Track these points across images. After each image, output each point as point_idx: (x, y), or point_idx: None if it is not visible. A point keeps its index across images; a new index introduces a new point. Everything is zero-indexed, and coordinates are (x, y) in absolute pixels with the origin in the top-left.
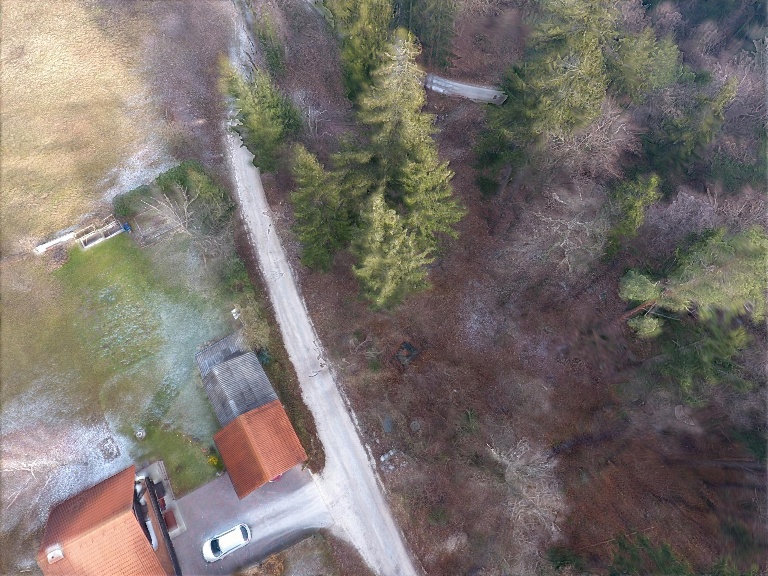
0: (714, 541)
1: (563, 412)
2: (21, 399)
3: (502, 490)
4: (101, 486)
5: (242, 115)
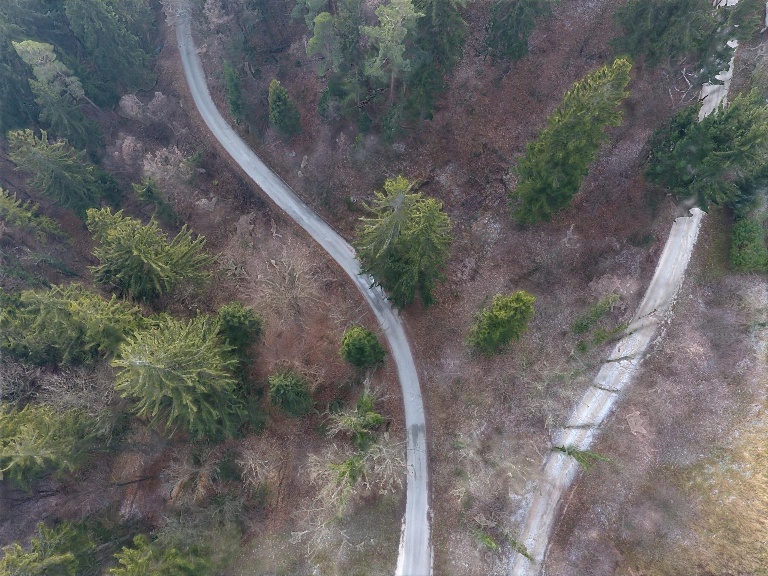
0: None
1: None
2: None
3: None
4: None
5: None
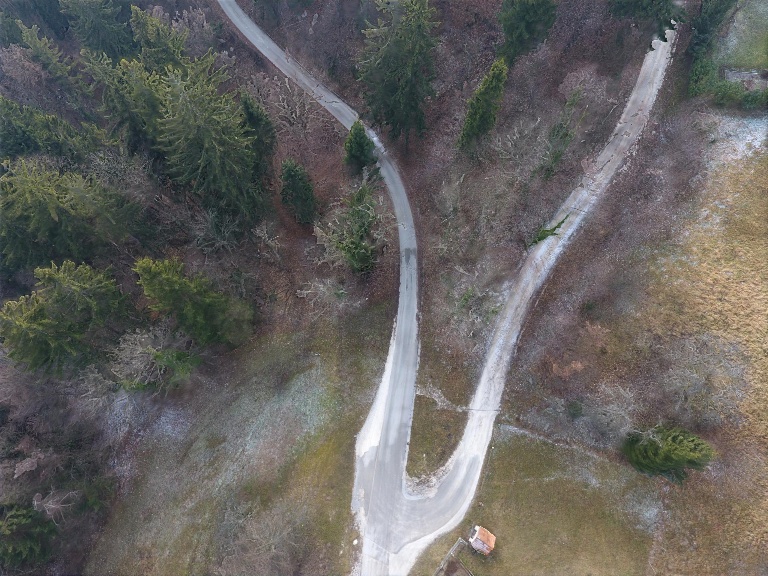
0: None
1: None
2: None
3: None
4: None
5: None
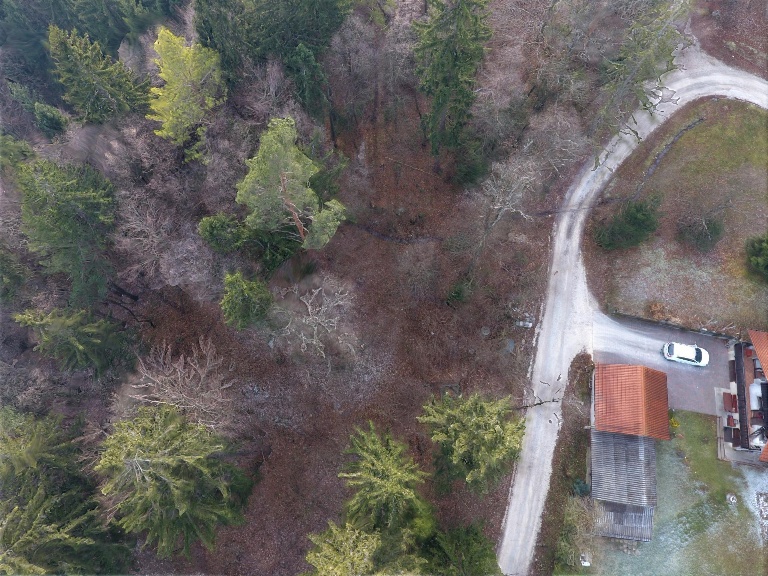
0: (355, 130)
1: (373, 255)
2: None
3: (460, 243)
4: None
5: None
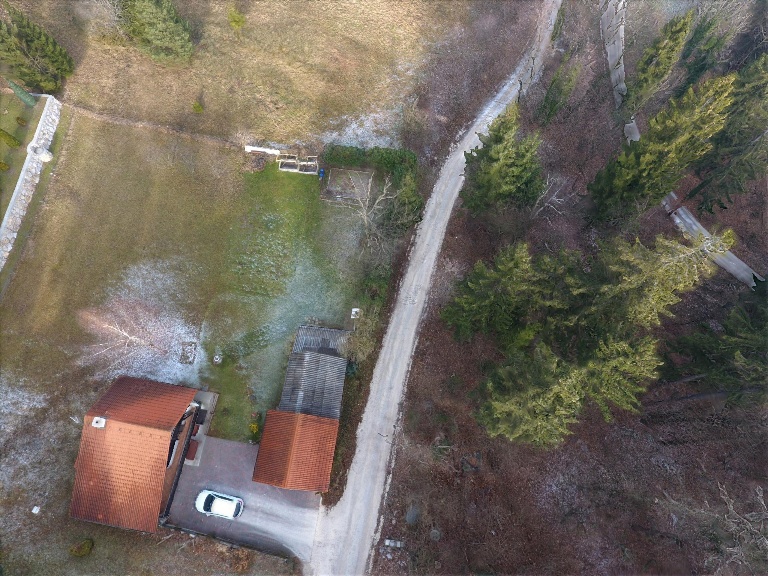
0: None
1: None
2: (157, 263)
3: None
4: (164, 387)
5: (482, 152)
